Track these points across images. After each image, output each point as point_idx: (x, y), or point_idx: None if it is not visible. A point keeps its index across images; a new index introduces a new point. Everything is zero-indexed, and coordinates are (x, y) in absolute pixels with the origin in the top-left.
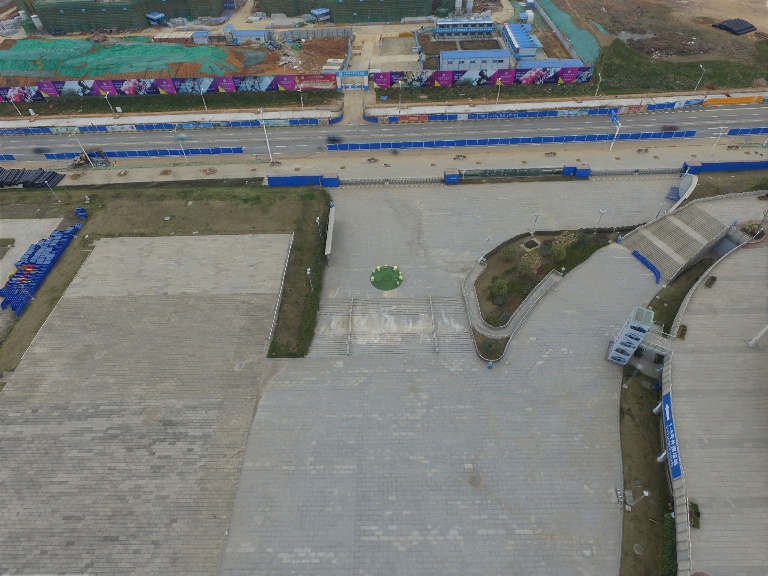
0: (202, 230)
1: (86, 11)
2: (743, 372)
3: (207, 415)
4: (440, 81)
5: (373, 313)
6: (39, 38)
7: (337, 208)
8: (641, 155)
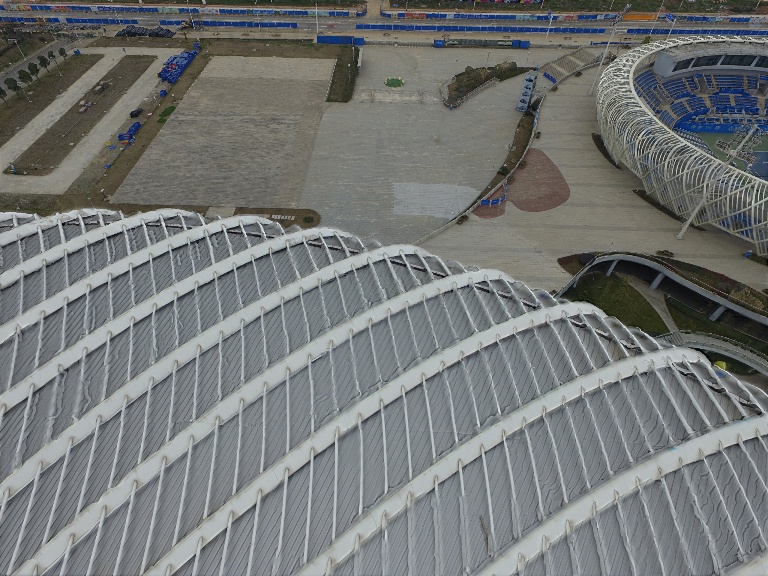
0: (278, 55)
1: None
2: (581, 102)
3: (295, 117)
4: None
5: (386, 93)
6: None
7: (363, 54)
8: (566, 40)
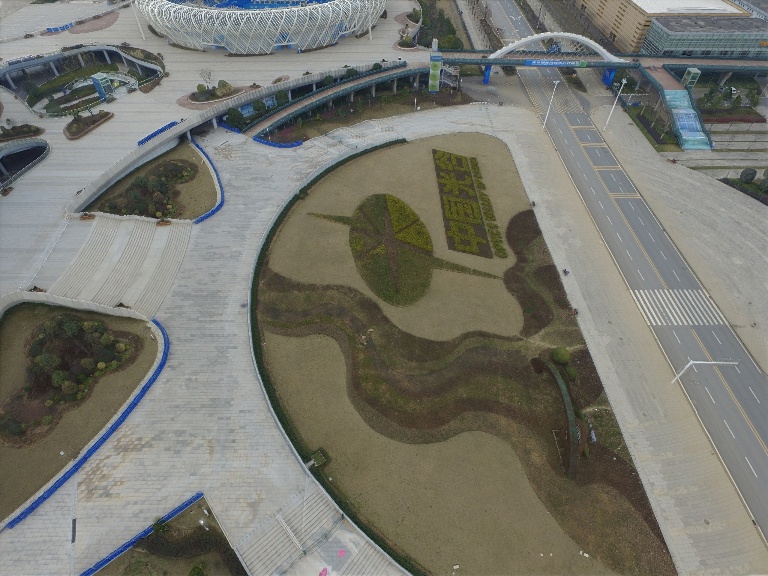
0: None
1: None
2: None
3: None
4: None
5: None
6: None
7: None
8: None
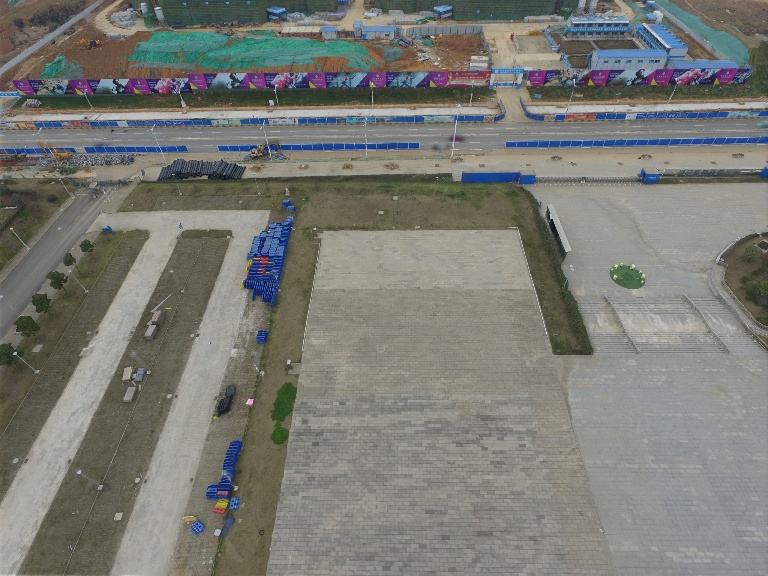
0: (423, 225)
1: (209, 4)
2: None
3: (522, 411)
4: (595, 80)
5: (635, 311)
6: (169, 30)
7: (543, 205)
8: None
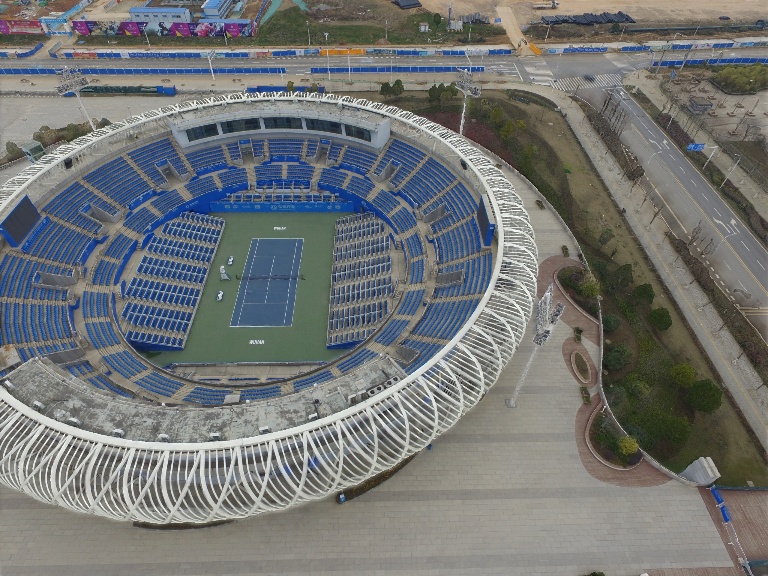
0: None
1: None
2: None
3: None
4: (130, 31)
5: None
6: None
7: None
8: (233, 83)
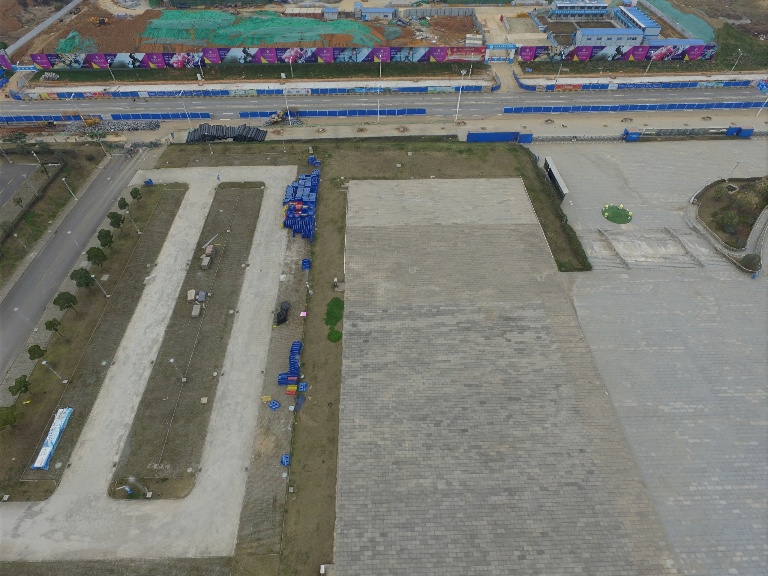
0: (437, 175)
1: None
2: None
3: (537, 313)
4: (579, 56)
5: (625, 240)
6: (177, 9)
7: (540, 160)
8: None
